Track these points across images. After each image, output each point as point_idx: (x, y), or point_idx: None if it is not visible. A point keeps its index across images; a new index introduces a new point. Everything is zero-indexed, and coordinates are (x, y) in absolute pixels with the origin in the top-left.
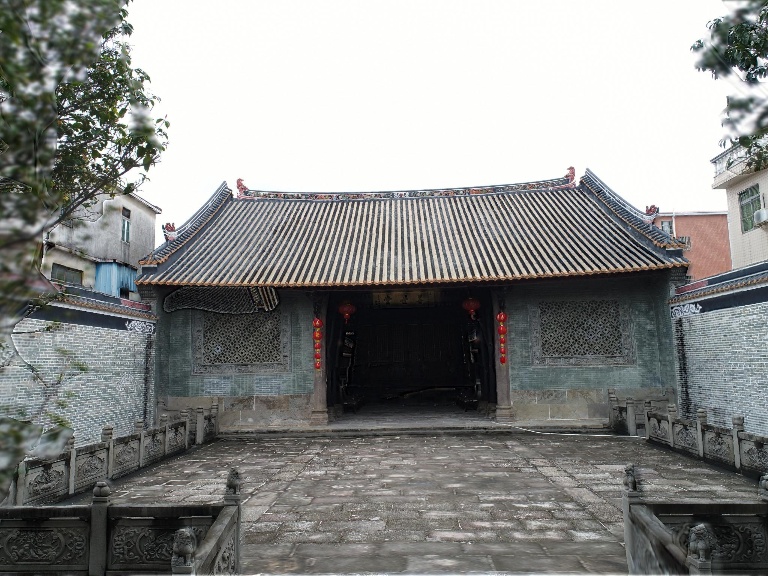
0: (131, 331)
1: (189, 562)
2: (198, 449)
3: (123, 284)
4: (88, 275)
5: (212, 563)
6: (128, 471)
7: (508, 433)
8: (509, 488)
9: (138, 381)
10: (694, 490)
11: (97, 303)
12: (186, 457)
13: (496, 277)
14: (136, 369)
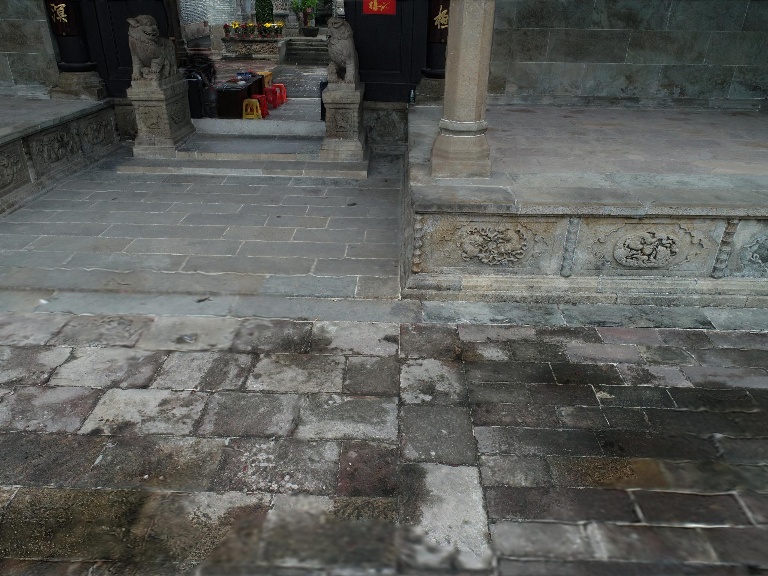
0: None
1: (334, 3)
2: None
3: None
4: None
5: (335, 6)
6: None
7: None
8: None
9: None
10: None
11: None
12: None
13: None
14: None
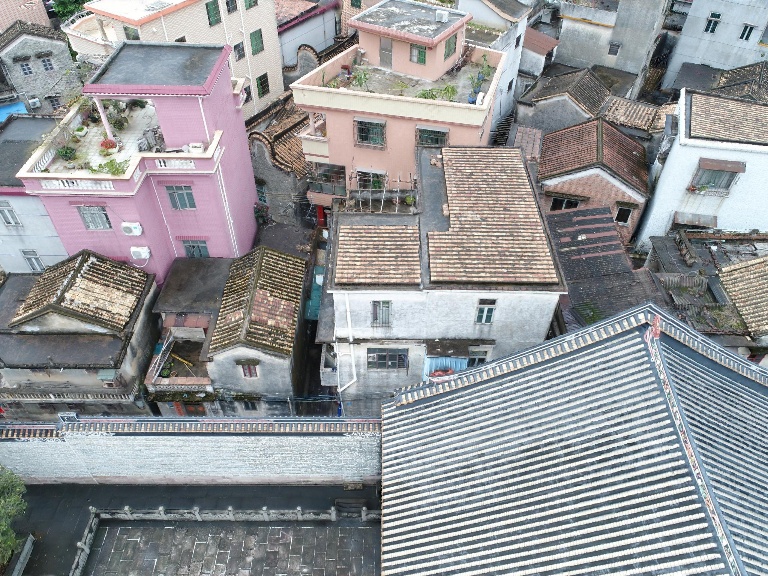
0: (354, 436)
1: None
2: (345, 526)
3: (441, 367)
4: (417, 349)
5: None
6: (254, 520)
7: None
8: None
9: (369, 455)
10: None
11: (312, 423)
12: (309, 531)
13: None
14: (365, 450)
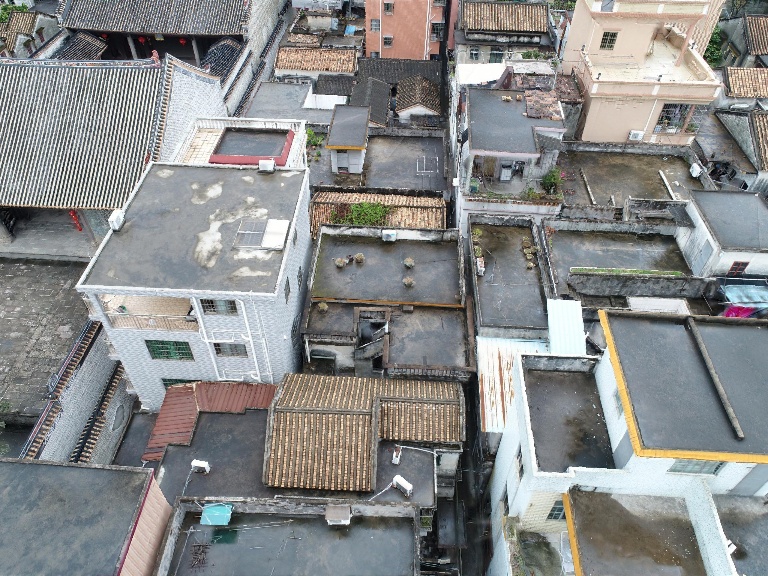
0: None
1: None
2: None
3: None
4: None
5: None
6: None
7: (86, 263)
8: (6, 352)
9: None
10: (57, 358)
11: None
12: None
13: (54, 207)
14: None
